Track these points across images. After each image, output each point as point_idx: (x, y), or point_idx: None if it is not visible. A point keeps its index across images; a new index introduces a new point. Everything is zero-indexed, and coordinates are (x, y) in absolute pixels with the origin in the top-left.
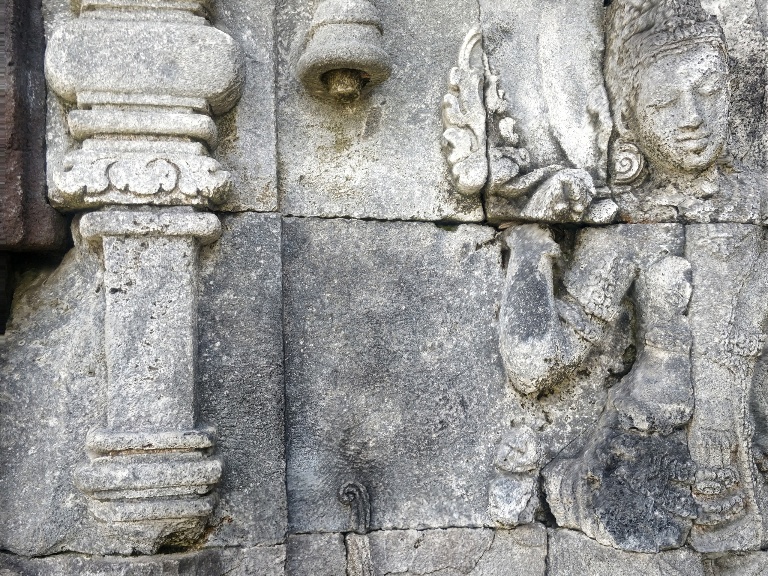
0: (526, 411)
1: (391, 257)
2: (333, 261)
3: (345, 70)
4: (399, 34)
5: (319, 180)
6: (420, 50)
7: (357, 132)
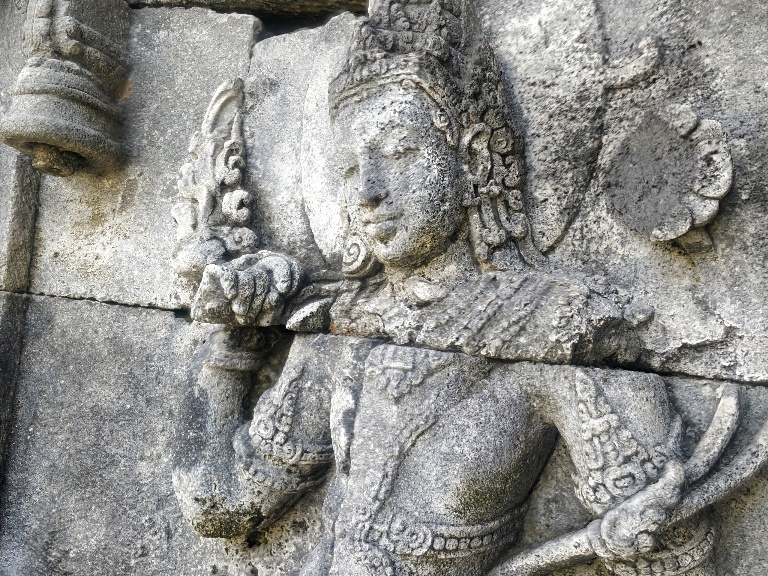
0: (230, 558)
1: (125, 347)
2: (72, 346)
3: (33, 144)
4: (165, 97)
5: (71, 258)
6: (183, 113)
7: (113, 207)
